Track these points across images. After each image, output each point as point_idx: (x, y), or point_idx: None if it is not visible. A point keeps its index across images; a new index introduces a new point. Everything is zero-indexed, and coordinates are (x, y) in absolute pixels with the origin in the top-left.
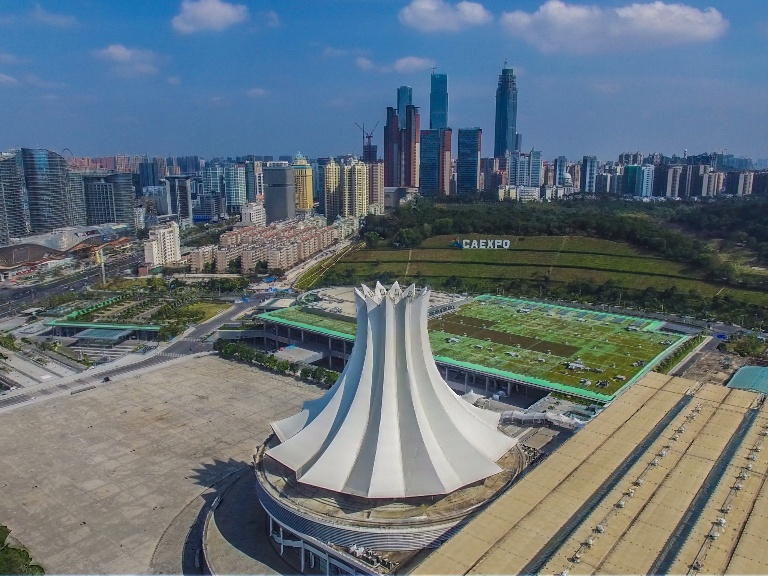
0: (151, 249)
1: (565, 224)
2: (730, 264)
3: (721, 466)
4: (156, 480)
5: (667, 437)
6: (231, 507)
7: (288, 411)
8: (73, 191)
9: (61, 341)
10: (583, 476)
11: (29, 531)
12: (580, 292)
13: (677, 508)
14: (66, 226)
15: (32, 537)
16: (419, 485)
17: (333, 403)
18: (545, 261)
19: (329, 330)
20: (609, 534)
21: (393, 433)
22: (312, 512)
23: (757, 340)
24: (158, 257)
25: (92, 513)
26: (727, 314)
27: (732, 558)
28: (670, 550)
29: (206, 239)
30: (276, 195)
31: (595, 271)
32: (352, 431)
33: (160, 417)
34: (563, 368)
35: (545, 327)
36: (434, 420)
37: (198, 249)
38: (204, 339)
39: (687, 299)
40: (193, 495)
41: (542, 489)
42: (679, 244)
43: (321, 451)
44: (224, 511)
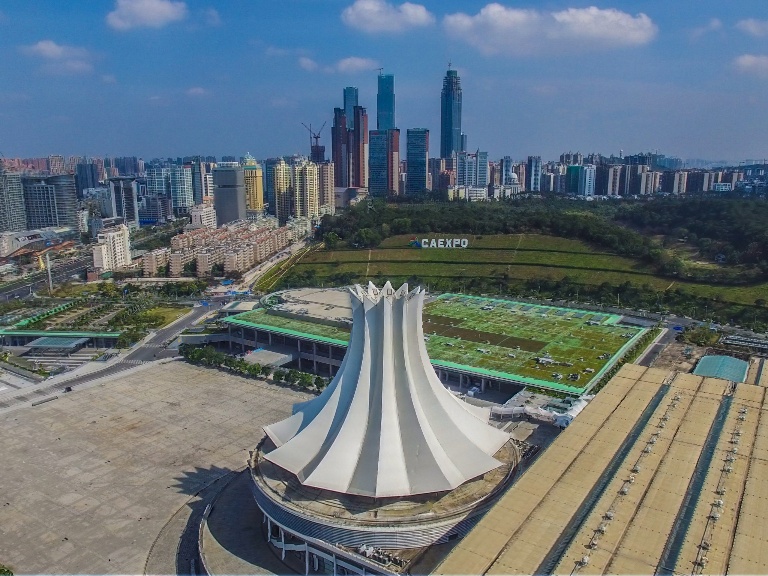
0: (100, 253)
1: (521, 223)
2: (678, 259)
3: (709, 451)
4: (137, 491)
5: (654, 425)
6: (224, 514)
7: (265, 415)
8: (11, 194)
9: (12, 351)
10: (583, 466)
11: (7, 550)
12: (539, 289)
13: (676, 492)
14: (5, 230)
15: (11, 557)
16: (424, 482)
17: (330, 404)
18: (503, 259)
19: (298, 332)
20: (619, 520)
21: (394, 432)
22: (318, 514)
23: (710, 331)
24: (108, 261)
25: (73, 528)
26: (679, 307)
27: (735, 537)
28: (678, 532)
29: (156, 242)
30: (226, 196)
31: (552, 268)
32: (352, 432)
33: (132, 426)
34: (534, 363)
35: (511, 323)
36: (433, 417)
37: (151, 252)
38: (167, 345)
39: (641, 293)
40: (178, 504)
41: (547, 480)
42: (630, 241)
43: (322, 453)
44: (217, 519)
